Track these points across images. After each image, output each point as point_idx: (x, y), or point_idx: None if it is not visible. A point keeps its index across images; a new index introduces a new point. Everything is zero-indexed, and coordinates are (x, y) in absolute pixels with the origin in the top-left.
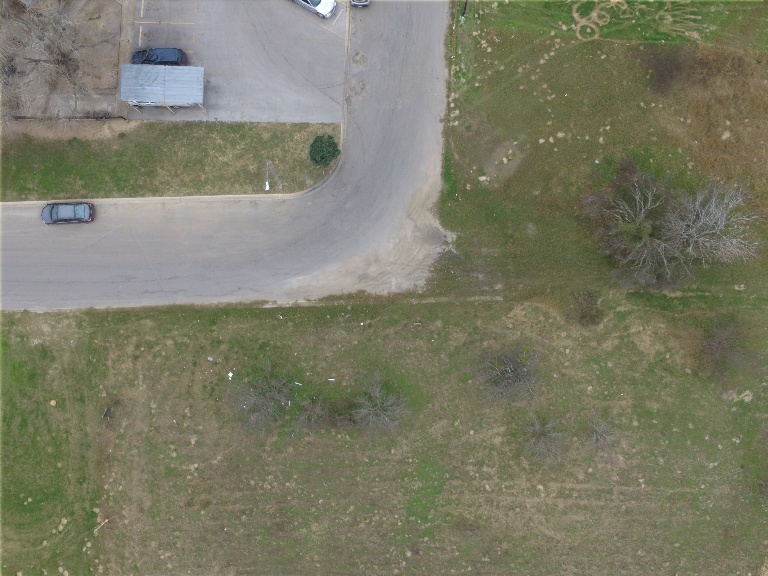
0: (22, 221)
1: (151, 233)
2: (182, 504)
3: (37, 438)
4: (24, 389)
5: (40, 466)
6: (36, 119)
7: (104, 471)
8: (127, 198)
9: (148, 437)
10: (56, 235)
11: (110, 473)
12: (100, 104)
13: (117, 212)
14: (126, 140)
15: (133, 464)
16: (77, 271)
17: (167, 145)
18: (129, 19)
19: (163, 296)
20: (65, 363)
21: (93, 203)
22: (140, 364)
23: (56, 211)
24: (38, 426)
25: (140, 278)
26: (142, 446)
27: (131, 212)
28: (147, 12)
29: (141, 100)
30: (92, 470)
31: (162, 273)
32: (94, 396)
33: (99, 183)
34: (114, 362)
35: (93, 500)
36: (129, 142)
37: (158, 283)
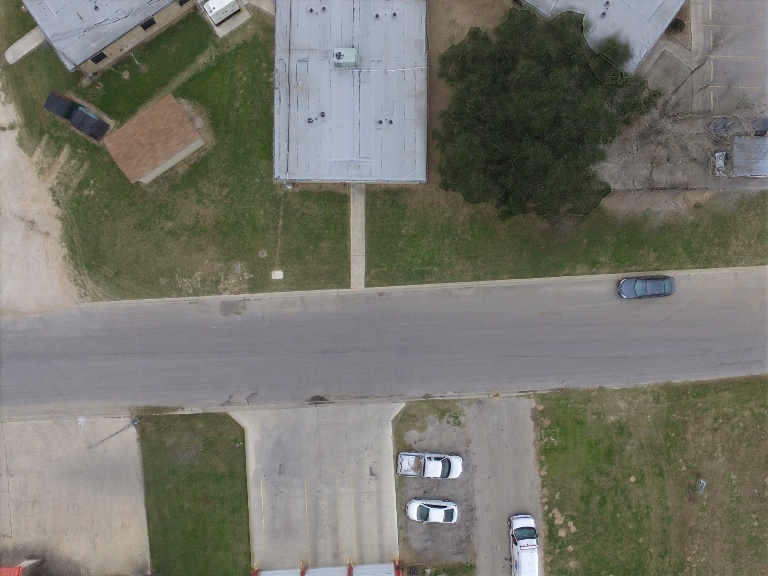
0: (593, 295)
1: (726, 304)
2: (764, 571)
3: (617, 515)
4: (601, 466)
5: (621, 543)
6: (616, 190)
7: (687, 544)
8: (700, 269)
9: (730, 508)
10: (629, 309)
11: (693, 545)
12: (675, 173)
13: (690, 283)
14: (702, 210)
15: (715, 535)
16: (653, 345)
17: (742, 214)
18: (699, 83)
19: (740, 367)
20: (643, 438)
21: (667, 275)
22: (719, 436)
23: (644, 286)
24: (617, 503)
25: (717, 350)
26: (724, 517)
27: (704, 283)
28: (716, 76)
29: (756, 174)
30: (674, 543)
31: (739, 344)
32: (673, 470)
33: (673, 254)
34: (693, 435)
35: (675, 573)
36: (705, 212)
37: (735, 354)
